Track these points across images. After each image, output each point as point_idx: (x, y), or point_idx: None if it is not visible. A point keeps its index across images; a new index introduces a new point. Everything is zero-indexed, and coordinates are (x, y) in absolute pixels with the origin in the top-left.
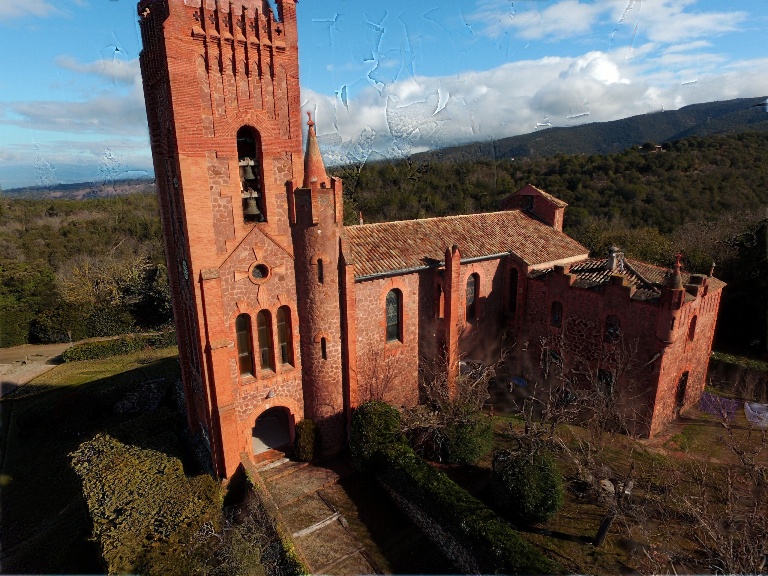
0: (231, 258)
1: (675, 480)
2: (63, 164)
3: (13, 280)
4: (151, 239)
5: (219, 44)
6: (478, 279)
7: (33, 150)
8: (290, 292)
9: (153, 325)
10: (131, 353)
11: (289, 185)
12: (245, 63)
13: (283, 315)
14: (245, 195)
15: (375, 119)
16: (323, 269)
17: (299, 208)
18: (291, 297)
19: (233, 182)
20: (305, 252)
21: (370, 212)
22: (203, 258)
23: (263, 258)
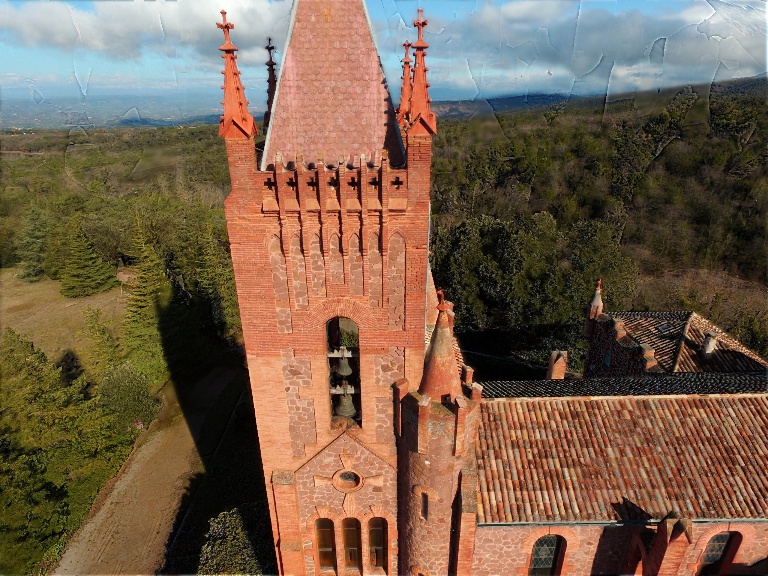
0: (311, 463)
1: None
2: None
3: None
4: None
5: (300, 218)
6: (738, 537)
7: None
8: (389, 504)
9: None
10: None
11: (397, 388)
12: (339, 237)
13: (380, 520)
14: (337, 391)
15: (702, 75)
16: (428, 505)
17: (405, 422)
18: (390, 509)
19: (316, 383)
20: (408, 475)
21: (654, 214)
22: (276, 460)
23: (353, 466)
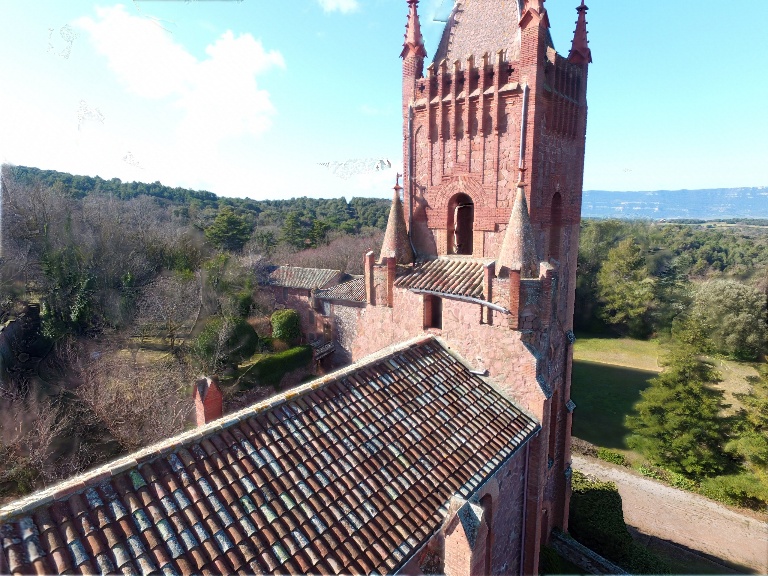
0: None
1: (117, 436)
2: None
3: None
4: None
5: None
6: None
7: None
8: None
9: None
10: None
11: None
12: None
13: None
14: None
15: None
16: None
17: None
18: None
19: None
20: None
21: None
22: None
23: None
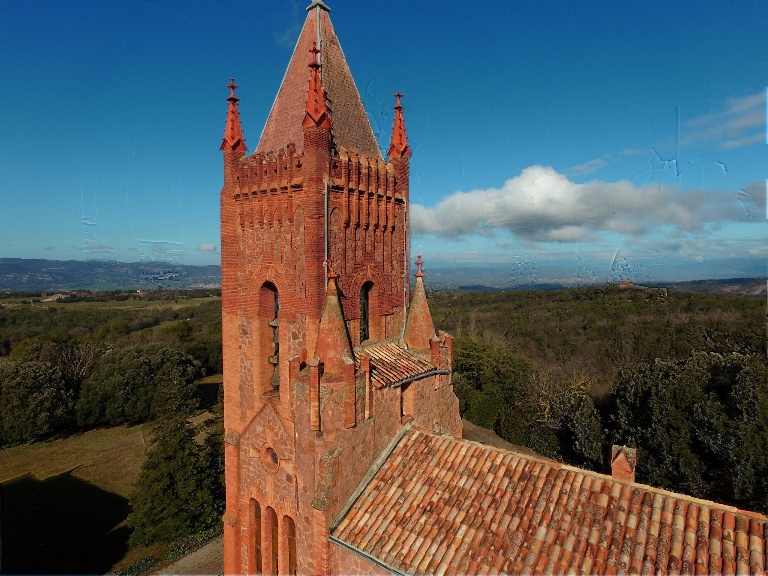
0: (249, 428)
1: None
2: (607, 272)
3: (500, 373)
4: (640, 361)
5: None
6: None
7: (575, 261)
8: None
9: (572, 461)
10: None
11: None
12: None
13: None
14: (274, 360)
15: None
16: (298, 493)
17: None
18: None
19: (255, 344)
20: None
21: None
22: (231, 418)
23: (274, 442)
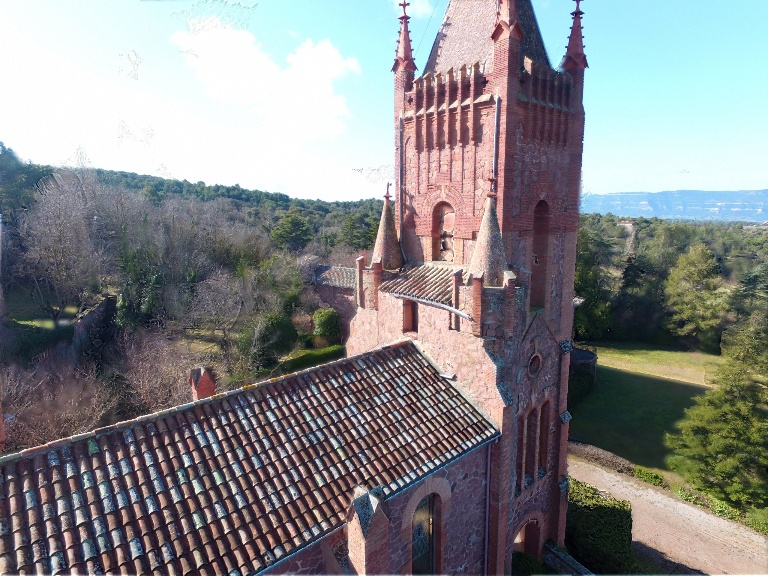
0: None
1: None
2: None
3: None
4: None
5: None
6: None
7: None
8: None
9: None
10: None
11: None
12: None
13: None
14: None
15: None
16: None
17: None
18: None
19: None
20: None
21: None
22: None
23: None
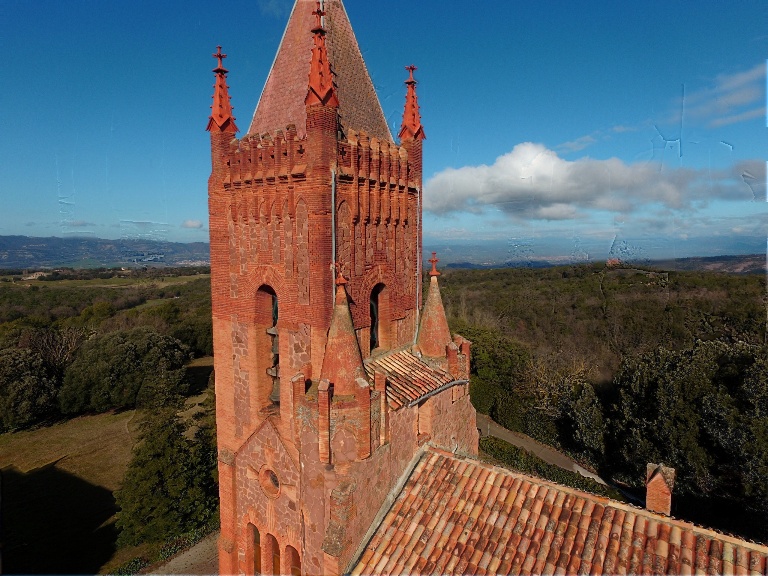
0: (246, 447)
1: None
2: (603, 254)
3: (496, 357)
4: (638, 346)
5: None
6: None
7: (572, 242)
8: None
9: (571, 449)
10: (521, 470)
11: None
12: None
13: None
14: (273, 372)
15: None
16: (305, 530)
17: None
18: None
19: (251, 354)
20: None
21: None
22: (225, 434)
23: (274, 464)
